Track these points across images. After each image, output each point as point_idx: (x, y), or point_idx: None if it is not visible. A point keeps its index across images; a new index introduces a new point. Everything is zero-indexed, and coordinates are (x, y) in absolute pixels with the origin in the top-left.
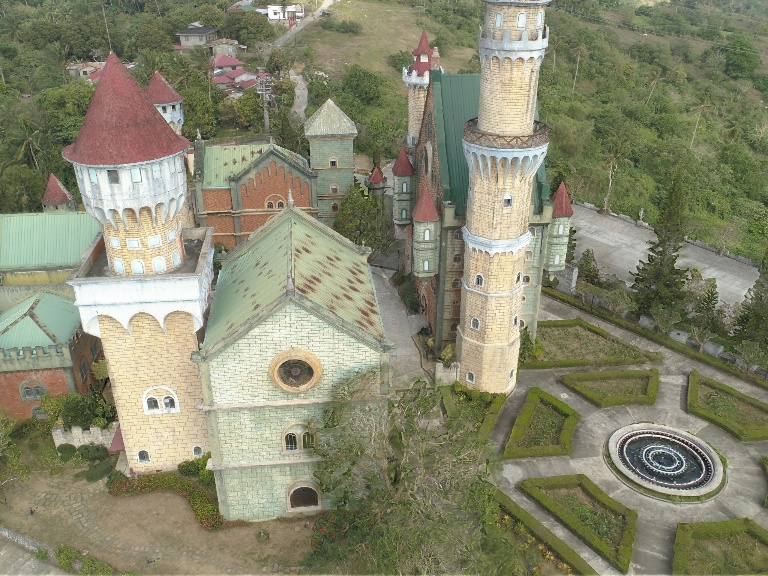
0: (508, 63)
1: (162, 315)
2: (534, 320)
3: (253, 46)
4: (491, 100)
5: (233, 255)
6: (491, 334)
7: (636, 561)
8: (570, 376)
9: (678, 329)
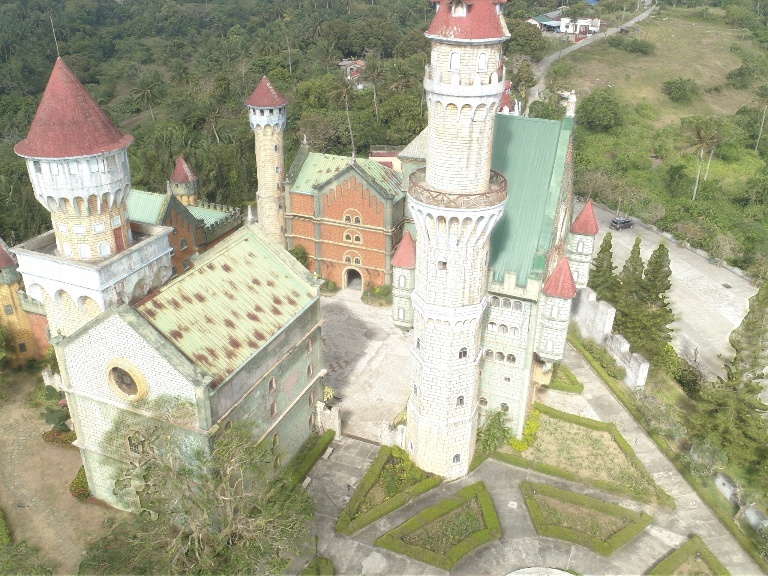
0: (441, 108)
1: (76, 296)
2: (520, 407)
3: (511, 58)
4: (429, 147)
5: (203, 258)
6: (427, 406)
7: None
8: (534, 485)
9: (725, 478)
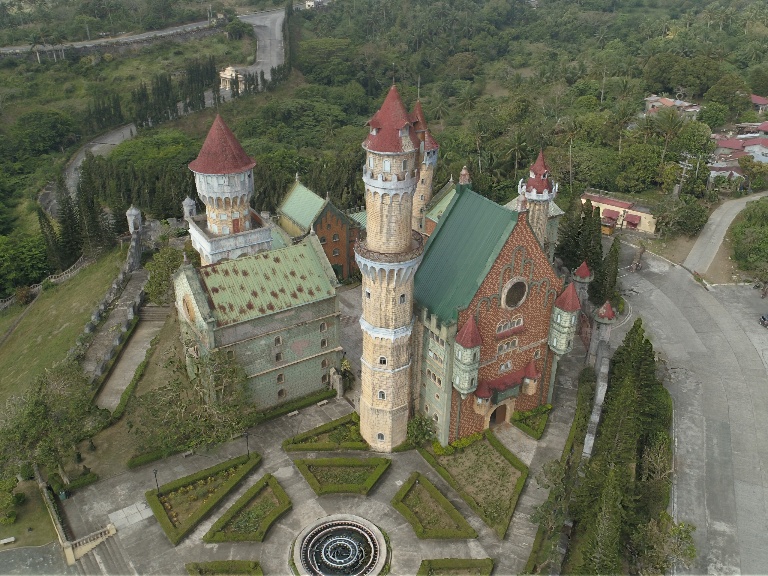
0: None
1: None
2: (443, 421)
3: None
4: None
5: None
6: (364, 391)
7: (220, 547)
8: (421, 477)
9: (560, 537)
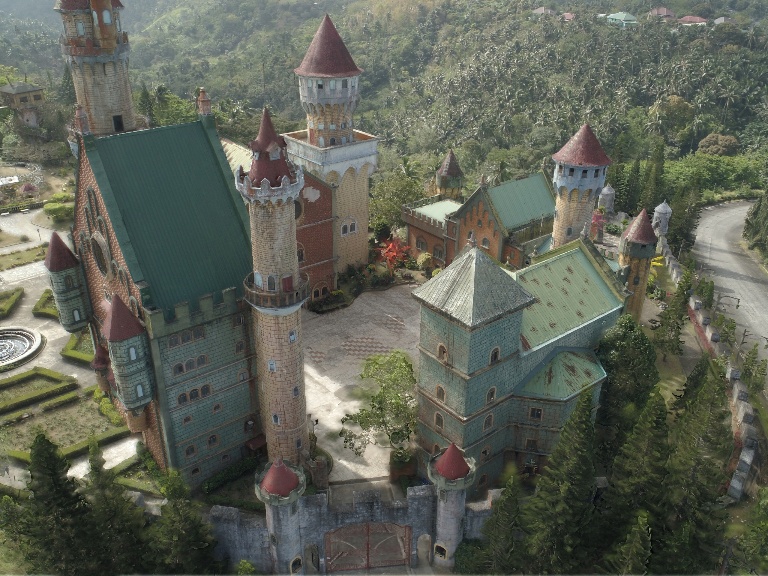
0: None
1: None
2: None
3: None
4: None
5: None
6: None
7: None
8: (66, 383)
9: None
